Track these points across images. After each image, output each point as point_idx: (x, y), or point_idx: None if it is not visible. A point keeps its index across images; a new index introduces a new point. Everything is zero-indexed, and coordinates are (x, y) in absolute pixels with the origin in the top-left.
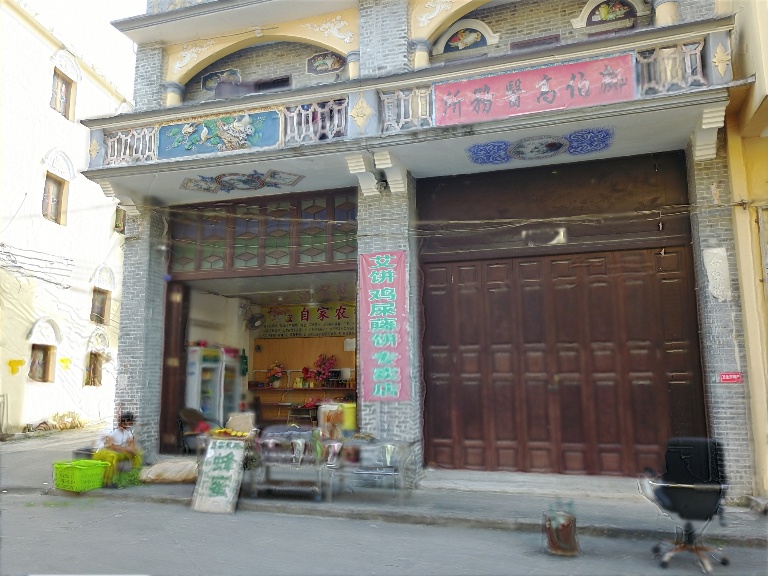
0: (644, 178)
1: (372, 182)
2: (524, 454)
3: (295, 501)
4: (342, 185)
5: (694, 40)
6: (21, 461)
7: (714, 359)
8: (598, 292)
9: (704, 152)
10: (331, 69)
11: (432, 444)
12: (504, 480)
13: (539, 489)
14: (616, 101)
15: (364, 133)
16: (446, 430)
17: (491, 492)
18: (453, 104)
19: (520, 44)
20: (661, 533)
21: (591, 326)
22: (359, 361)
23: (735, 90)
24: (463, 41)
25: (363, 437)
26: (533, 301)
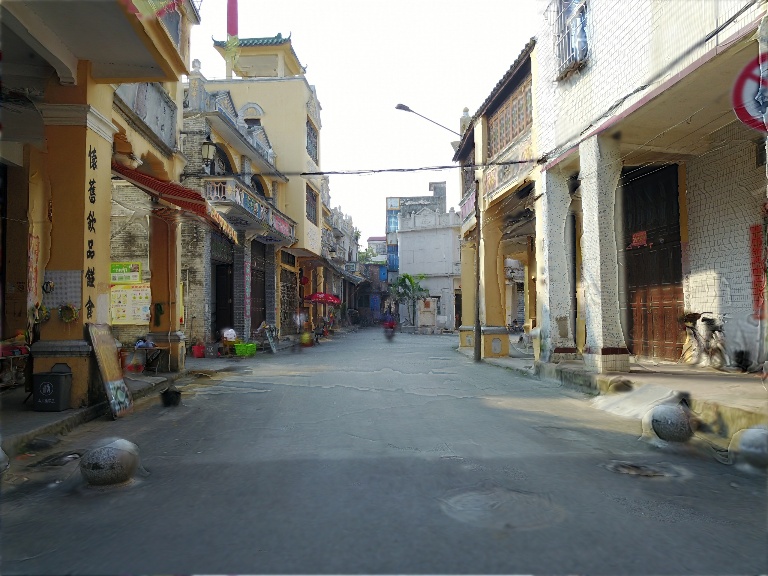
0: None
1: None
2: None
3: None
4: None
5: None
6: None
7: None
8: None
9: None
10: None
11: None
12: None
13: None
14: None
15: None
16: None
17: None
18: None
19: None
20: None
21: None
22: None
23: None
24: None
25: None
26: None
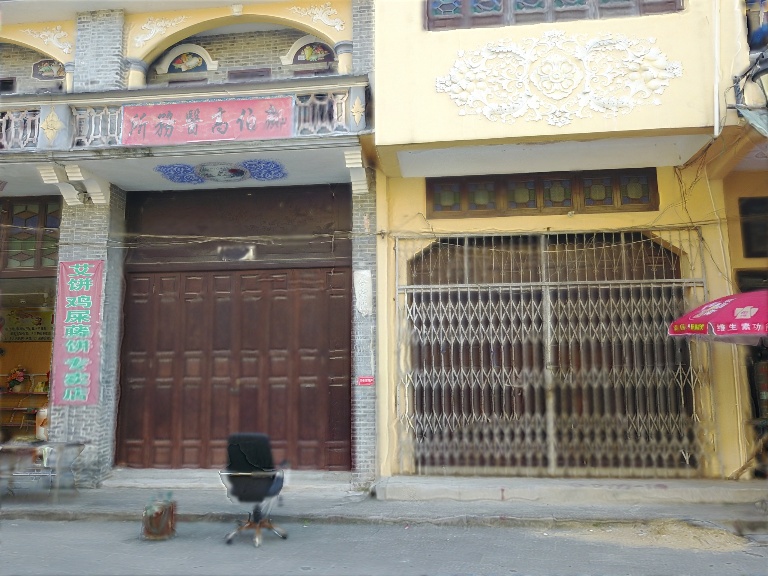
0: (322, 205)
1: (73, 193)
2: (206, 452)
3: None
4: (54, 193)
5: (341, 91)
6: None
7: (355, 365)
8: (279, 305)
9: (358, 187)
10: (56, 76)
11: (124, 445)
12: (184, 477)
13: (208, 484)
14: (276, 137)
15: (53, 146)
16: (138, 432)
17: (165, 488)
18: (139, 126)
19: (236, 73)
20: (240, 515)
21: (271, 335)
22: (52, 366)
23: (364, 138)
24: (186, 64)
25: (25, 440)
26: (224, 311)
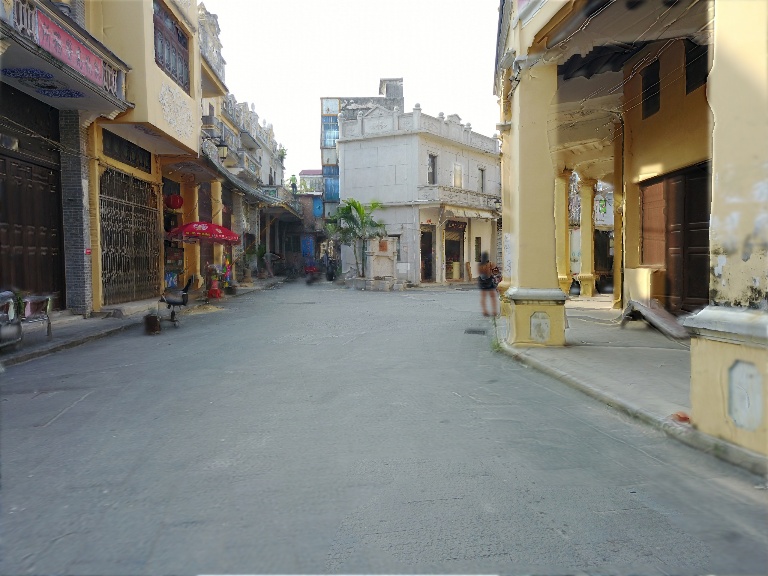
0: None
1: None
2: None
3: (13, 352)
4: None
5: None
6: None
7: None
8: (29, 191)
9: None
10: None
11: None
12: None
13: None
14: None
15: None
16: None
17: None
18: None
19: None
20: (166, 317)
21: None
22: None
23: None
24: None
25: None
26: (2, 190)
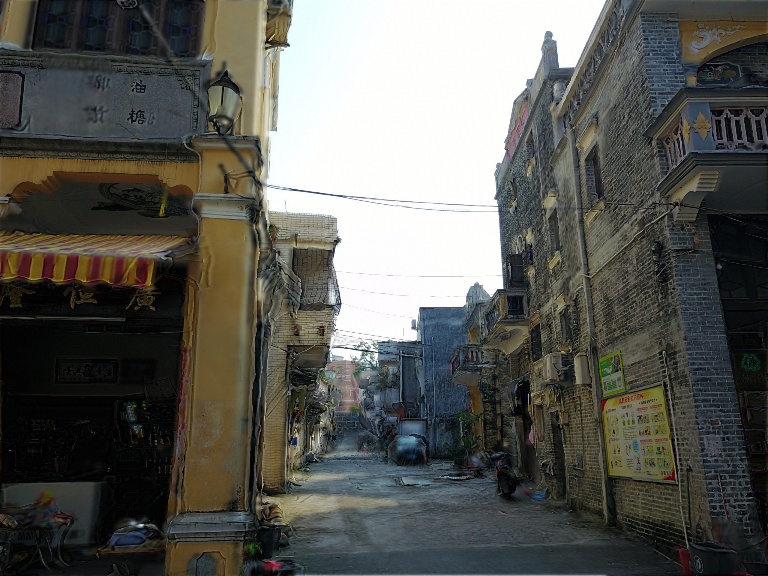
0: None
1: None
2: None
3: None
4: None
5: None
6: (476, 568)
7: None
8: None
9: None
10: None
11: None
12: None
13: None
14: None
15: None
16: None
17: None
18: None
19: None
20: None
21: None
22: None
23: None
24: None
25: None
26: None
